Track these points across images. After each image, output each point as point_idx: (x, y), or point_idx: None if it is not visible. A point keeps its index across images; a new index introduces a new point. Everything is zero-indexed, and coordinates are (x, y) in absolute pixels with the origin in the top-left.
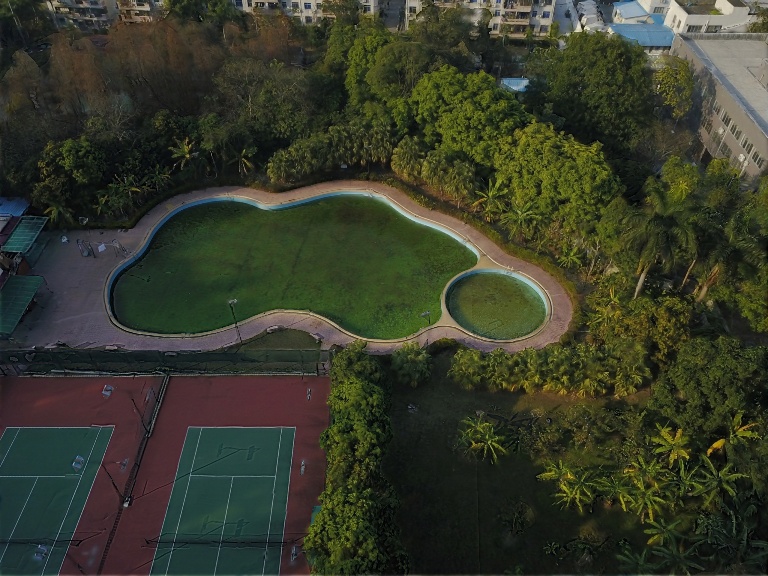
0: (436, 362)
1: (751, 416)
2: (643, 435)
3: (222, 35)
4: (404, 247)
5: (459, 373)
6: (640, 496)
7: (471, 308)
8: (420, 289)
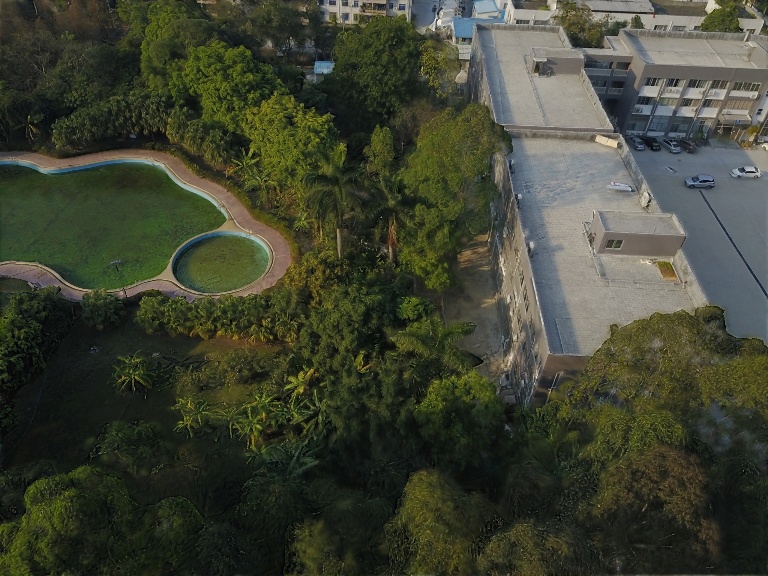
0: (137, 310)
1: (370, 357)
2: (283, 374)
3: (33, 9)
4: (162, 211)
5: (140, 318)
6: (246, 424)
7: (198, 265)
8: (159, 248)
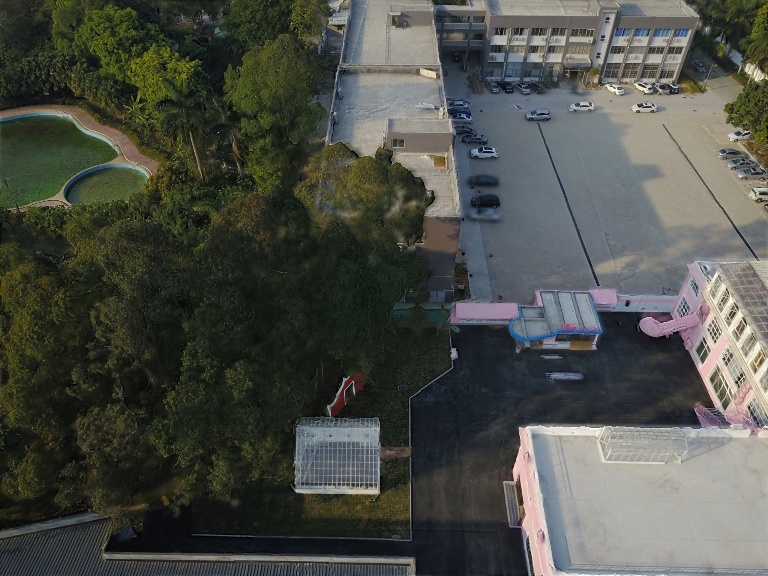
0: None
1: None
2: None
3: None
4: (65, 151)
5: (26, 223)
6: None
7: (88, 190)
8: (57, 178)
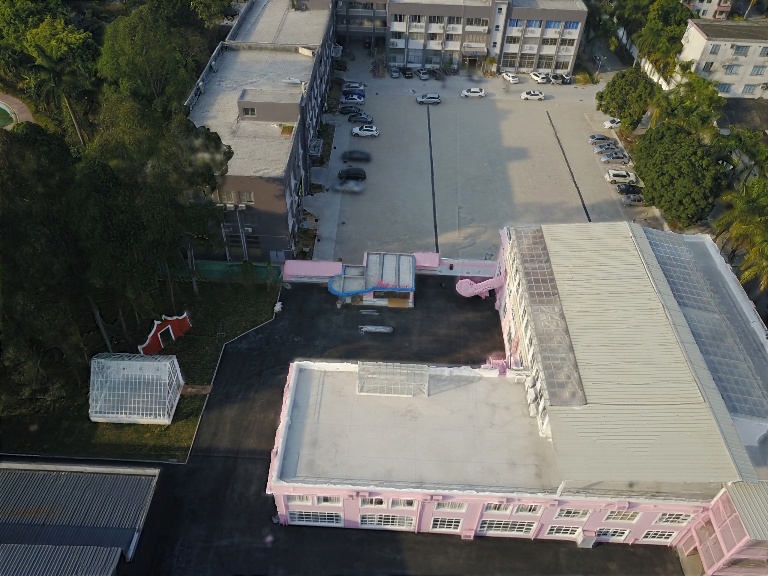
0: None
1: None
2: None
3: None
4: None
5: None
6: None
7: None
8: None
